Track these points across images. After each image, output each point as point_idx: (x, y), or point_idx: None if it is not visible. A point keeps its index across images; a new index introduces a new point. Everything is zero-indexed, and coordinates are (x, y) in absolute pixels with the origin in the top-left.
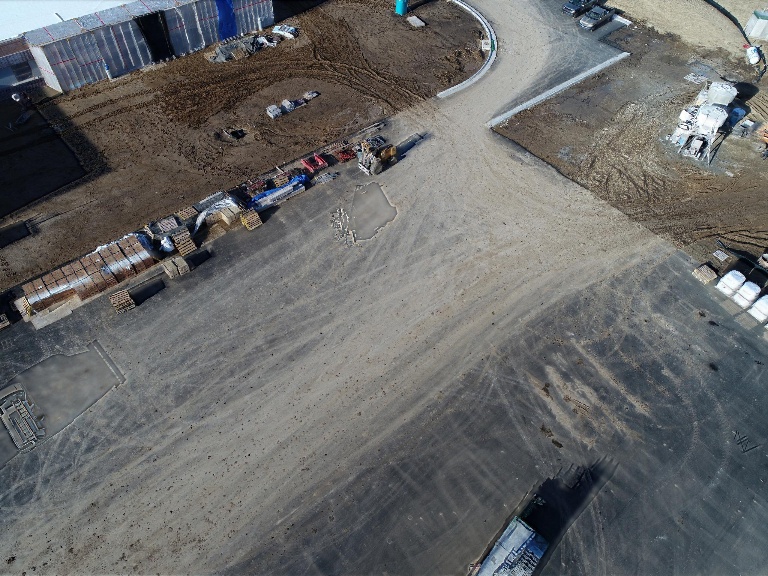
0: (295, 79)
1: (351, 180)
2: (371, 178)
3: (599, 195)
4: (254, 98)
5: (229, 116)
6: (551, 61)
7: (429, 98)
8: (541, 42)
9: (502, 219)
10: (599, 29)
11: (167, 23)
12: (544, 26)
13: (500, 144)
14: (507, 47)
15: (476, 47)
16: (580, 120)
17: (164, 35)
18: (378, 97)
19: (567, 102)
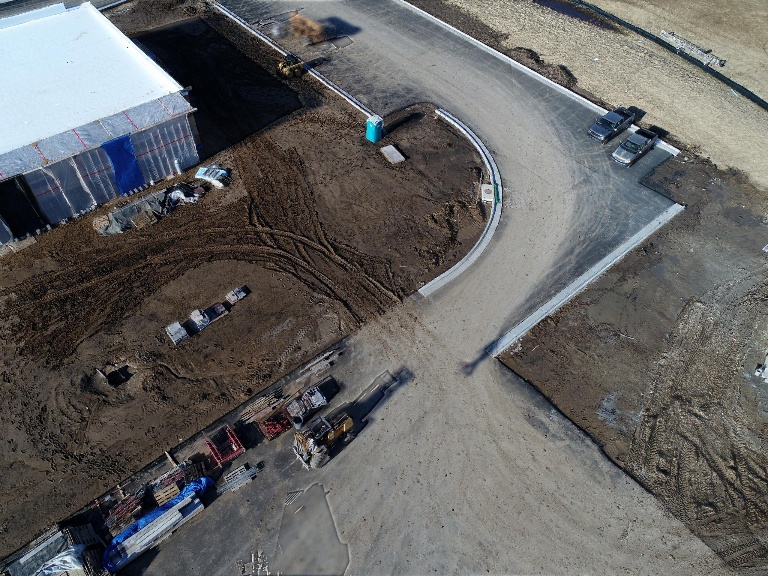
0: (217, 263)
1: (280, 480)
2: (312, 475)
3: (670, 506)
4: (153, 302)
5: (111, 339)
6: (577, 221)
7: (407, 297)
8: (562, 187)
9: (519, 572)
10: (638, 163)
11: (31, 188)
12: (564, 158)
13: (511, 392)
14: (516, 196)
15: (474, 196)
16: (626, 336)
17: (29, 203)
18: (334, 296)
19: (605, 300)
